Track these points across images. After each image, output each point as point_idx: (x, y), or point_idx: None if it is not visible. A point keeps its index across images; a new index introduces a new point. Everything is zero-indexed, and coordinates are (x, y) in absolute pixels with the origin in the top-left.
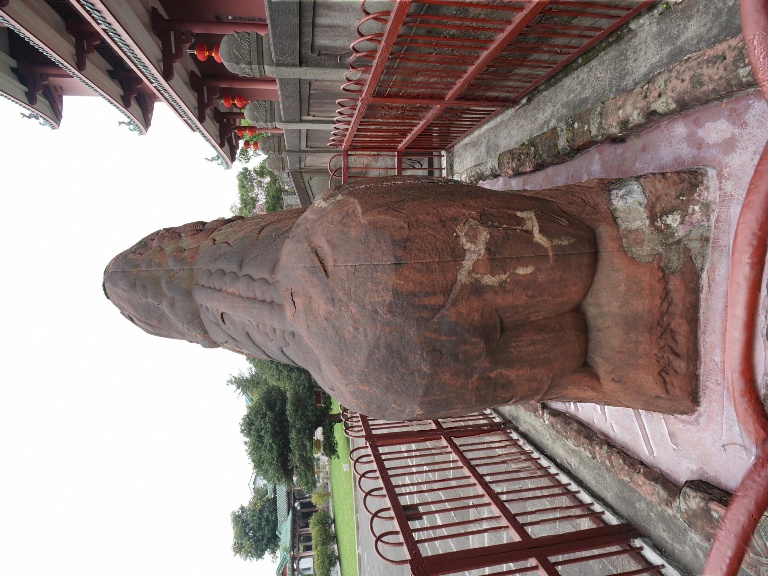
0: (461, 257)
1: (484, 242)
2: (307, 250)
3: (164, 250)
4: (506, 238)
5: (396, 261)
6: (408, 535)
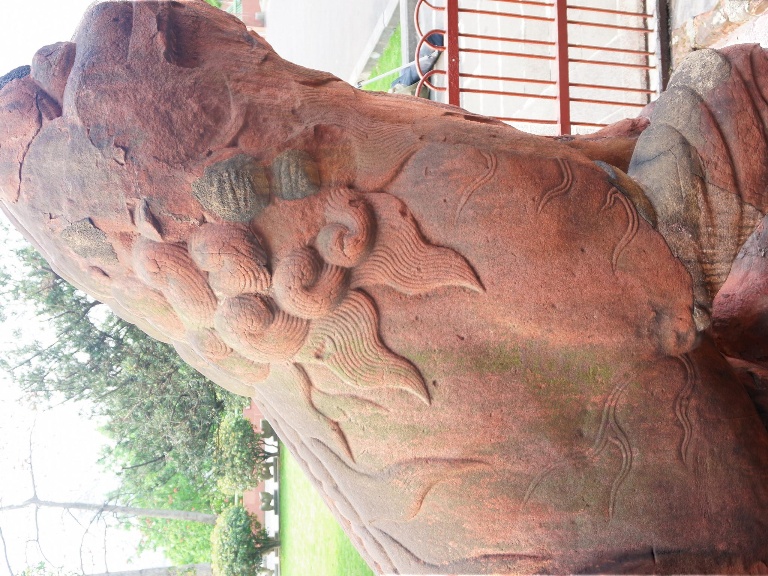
0: None
1: None
2: None
3: (174, 312)
4: None
5: None
6: None
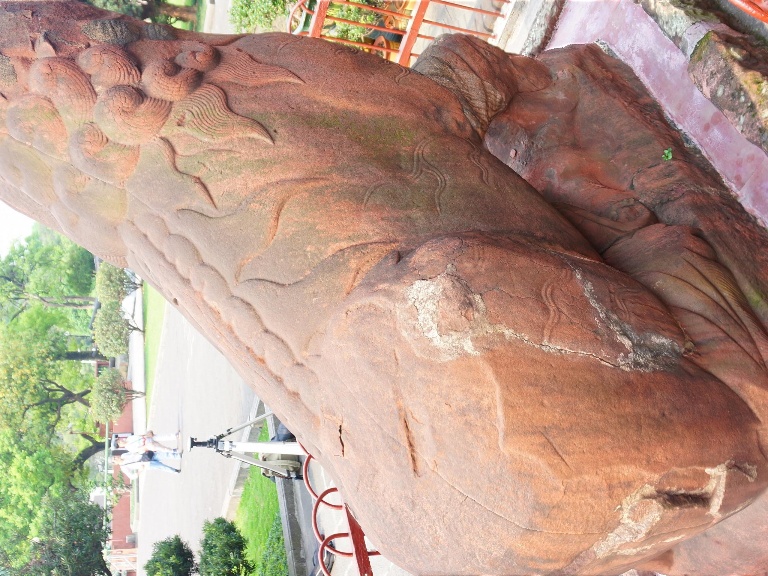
0: (610, 528)
1: (649, 526)
2: (390, 405)
3: (60, 116)
4: (677, 517)
5: (529, 527)
6: (361, 546)
